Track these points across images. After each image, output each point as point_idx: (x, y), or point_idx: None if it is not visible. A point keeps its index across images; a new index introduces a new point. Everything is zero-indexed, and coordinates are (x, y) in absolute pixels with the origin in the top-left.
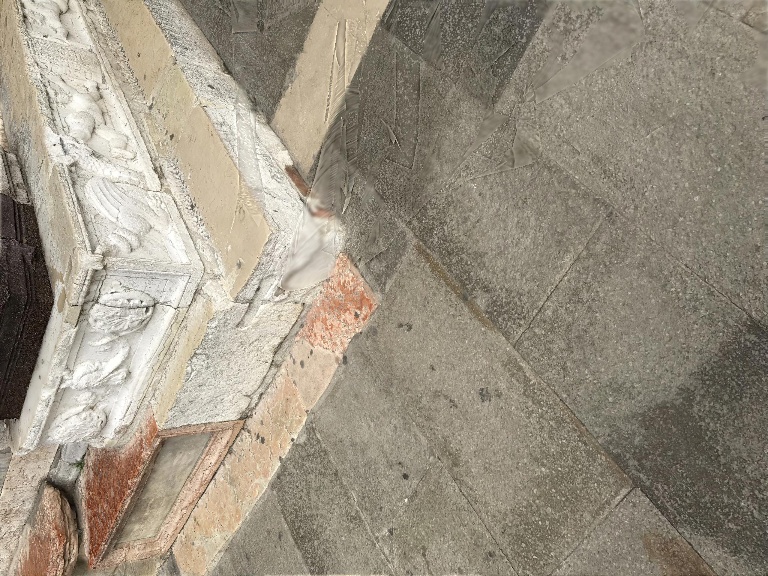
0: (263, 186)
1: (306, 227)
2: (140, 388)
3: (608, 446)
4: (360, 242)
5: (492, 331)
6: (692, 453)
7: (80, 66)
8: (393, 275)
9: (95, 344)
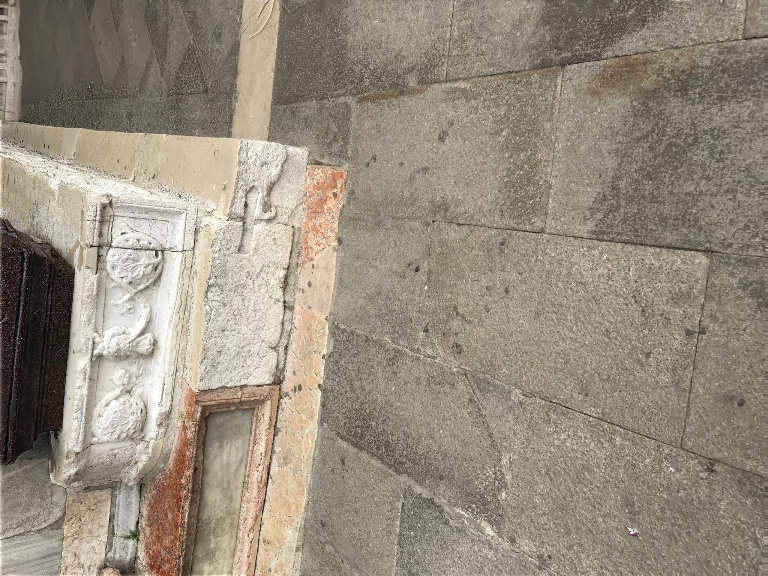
0: None
1: None
2: (170, 358)
3: (533, 63)
4: None
5: (428, 89)
6: (581, 1)
7: (71, 173)
8: (349, 138)
9: (118, 302)
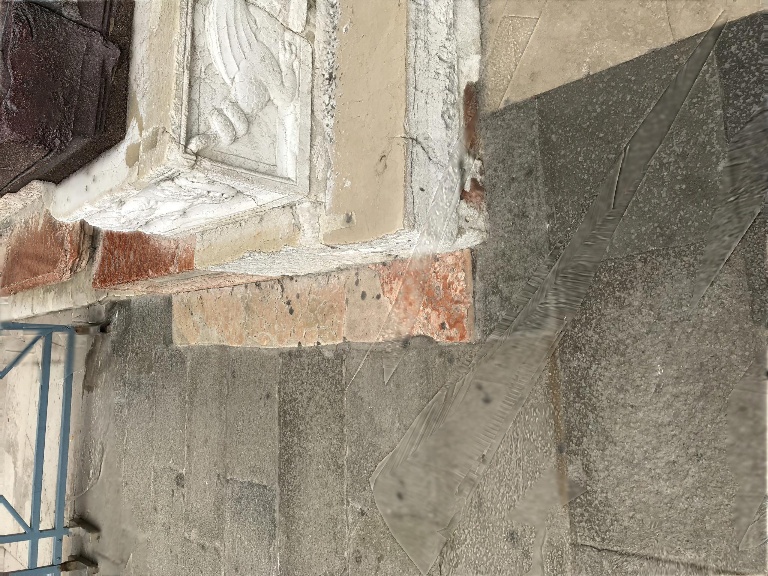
0: (425, 134)
1: (438, 440)
2: (190, 226)
3: None
4: (485, 572)
5: (563, 508)
6: None
7: None
8: None
9: (156, 194)
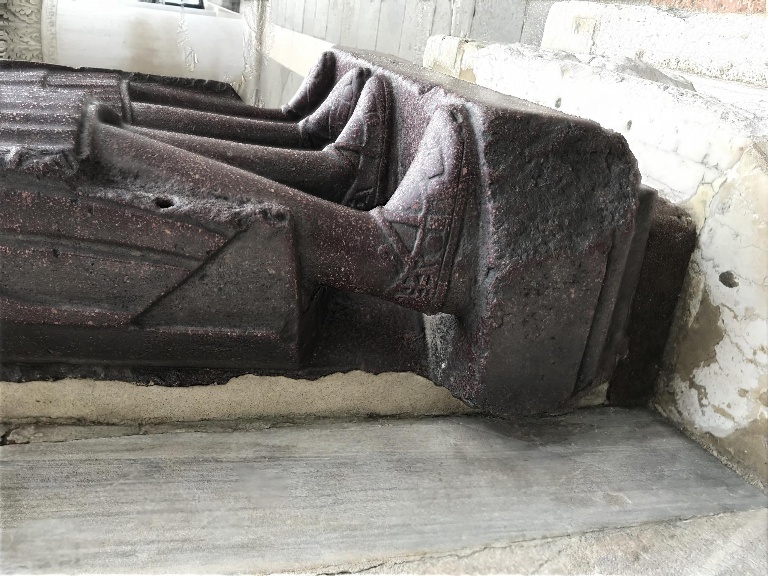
0: None
1: None
2: None
3: None
4: None
5: None
6: None
7: None
8: None
9: None
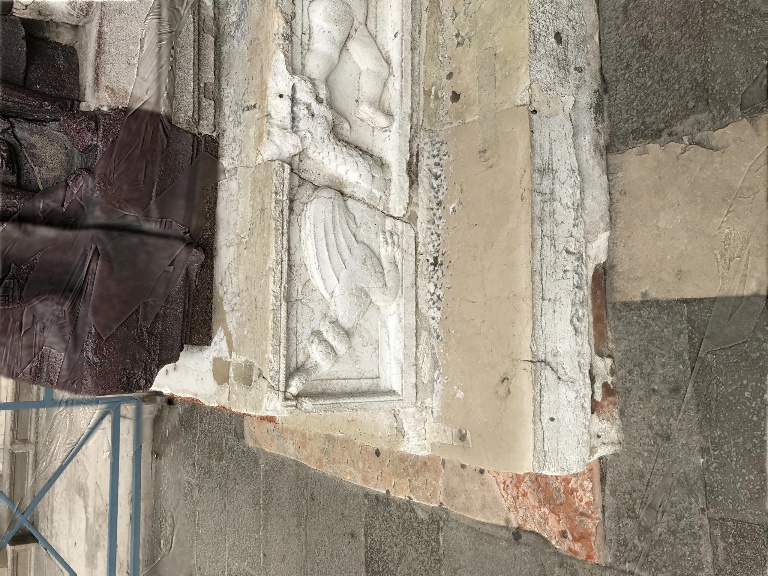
0: (554, 350)
1: None
2: None
3: None
4: None
5: None
6: None
7: None
8: (646, 571)
9: None
